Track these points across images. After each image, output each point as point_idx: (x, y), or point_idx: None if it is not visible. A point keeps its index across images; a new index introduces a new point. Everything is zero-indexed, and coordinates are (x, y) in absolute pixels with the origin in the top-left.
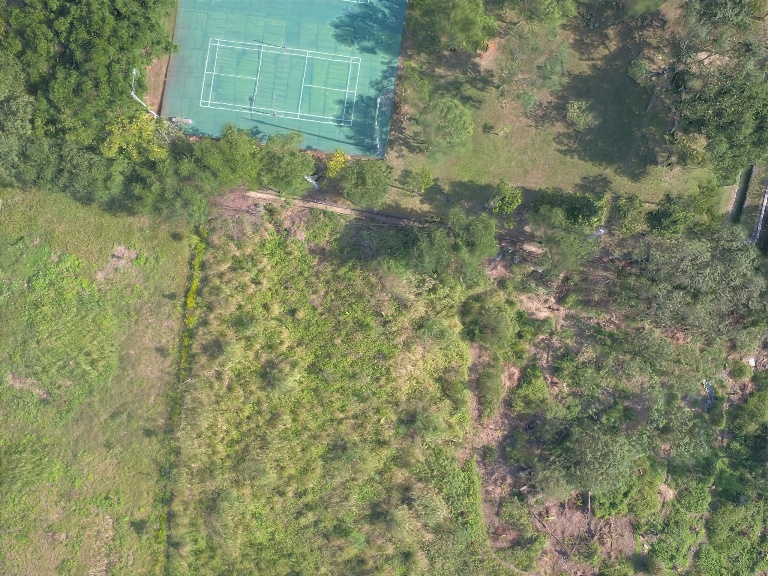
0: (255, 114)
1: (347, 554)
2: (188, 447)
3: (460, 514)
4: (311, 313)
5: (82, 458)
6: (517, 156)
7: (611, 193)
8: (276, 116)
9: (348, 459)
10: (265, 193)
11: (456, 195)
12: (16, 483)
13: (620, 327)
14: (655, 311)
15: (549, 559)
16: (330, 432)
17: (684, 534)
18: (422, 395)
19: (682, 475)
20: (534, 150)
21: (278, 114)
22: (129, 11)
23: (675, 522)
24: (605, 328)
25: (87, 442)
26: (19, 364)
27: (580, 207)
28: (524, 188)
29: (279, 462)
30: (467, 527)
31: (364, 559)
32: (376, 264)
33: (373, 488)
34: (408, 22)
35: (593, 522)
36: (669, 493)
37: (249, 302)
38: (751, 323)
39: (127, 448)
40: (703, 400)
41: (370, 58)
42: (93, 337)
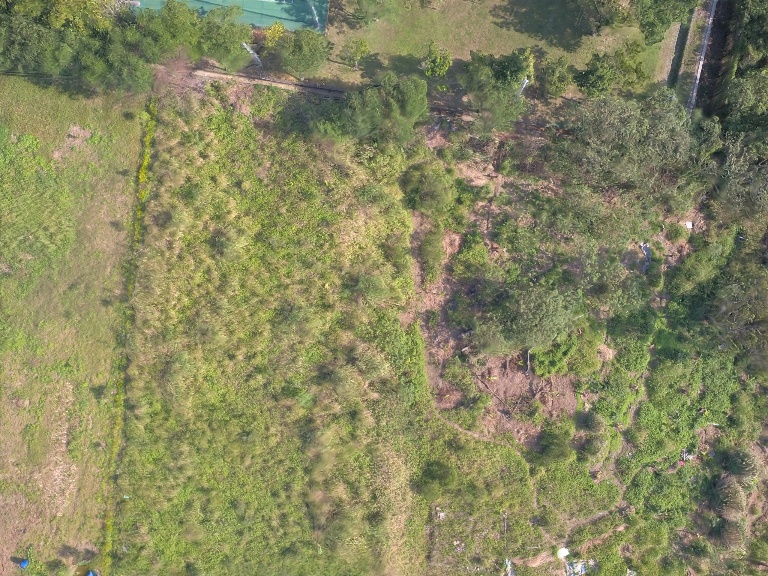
0: None
1: (295, 414)
2: (140, 311)
3: (403, 374)
4: (258, 185)
5: (43, 328)
6: (454, 29)
7: None
8: None
9: (292, 319)
10: (212, 72)
11: (396, 68)
12: None
13: (558, 193)
14: (587, 168)
15: (492, 418)
16: (276, 297)
17: (624, 392)
18: (364, 259)
19: (621, 334)
20: (471, 23)
21: None
22: None
23: (614, 380)
24: (543, 194)
25: (47, 313)
26: None
27: (508, 64)
28: (462, 60)
29: (228, 326)
30: (410, 385)
31: (311, 419)
32: (317, 132)
33: (319, 351)
34: None
35: (534, 382)
36: (608, 352)
37: (198, 175)
38: None
39: (85, 318)
40: (641, 262)
41: None
42: (51, 213)
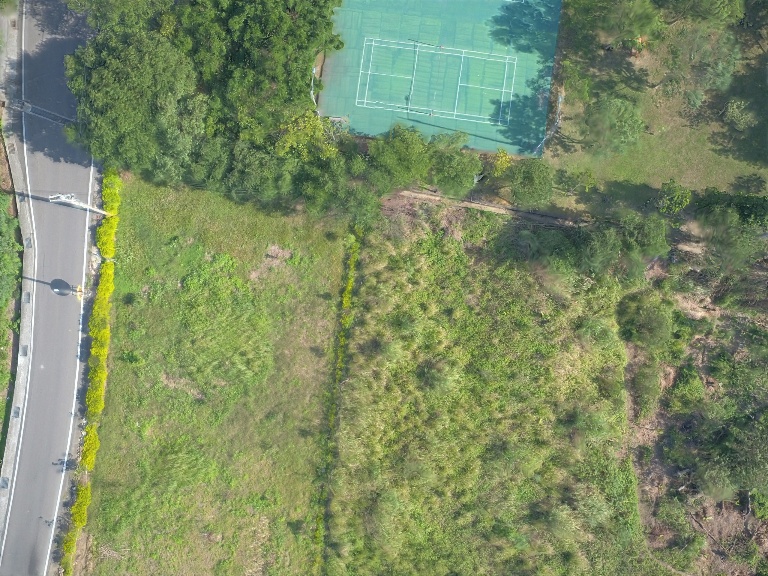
0: (411, 113)
1: (506, 554)
2: (350, 447)
3: (619, 514)
4: (467, 313)
5: (238, 458)
6: (672, 156)
7: (765, 193)
8: (432, 115)
9: (511, 459)
10: (420, 193)
11: (611, 195)
12: (172, 483)
13: None
14: None
15: (706, 559)
16: (489, 432)
17: None
18: (581, 395)
19: None
20: (689, 150)
21: (434, 113)
22: (305, 10)
23: None
24: (760, 328)
25: (243, 442)
26: (173, 364)
27: (752, 207)
28: None
29: (438, 462)
30: (628, 527)
31: (523, 559)
32: (537, 264)
33: (531, 488)
34: (563, 21)
35: (750, 522)
36: None
37: (406, 302)
38: None
39: (283, 448)
40: None
41: (526, 57)
42: (248, 337)
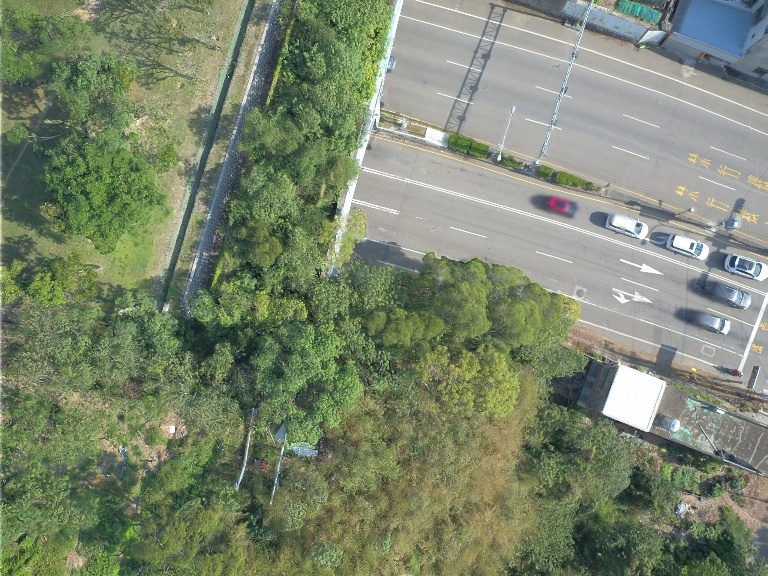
0: None
1: None
2: None
3: None
4: None
5: None
6: None
7: (36, 254)
8: None
9: None
10: None
11: None
12: None
13: (39, 390)
14: None
15: None
16: None
17: None
18: None
19: (89, 542)
20: None
21: None
22: None
23: None
24: (24, 390)
25: None
26: None
27: None
28: None
29: None
30: None
31: None
32: None
33: None
34: None
35: None
36: (77, 560)
37: None
38: (154, 391)
39: None
40: (119, 466)
41: None
42: None
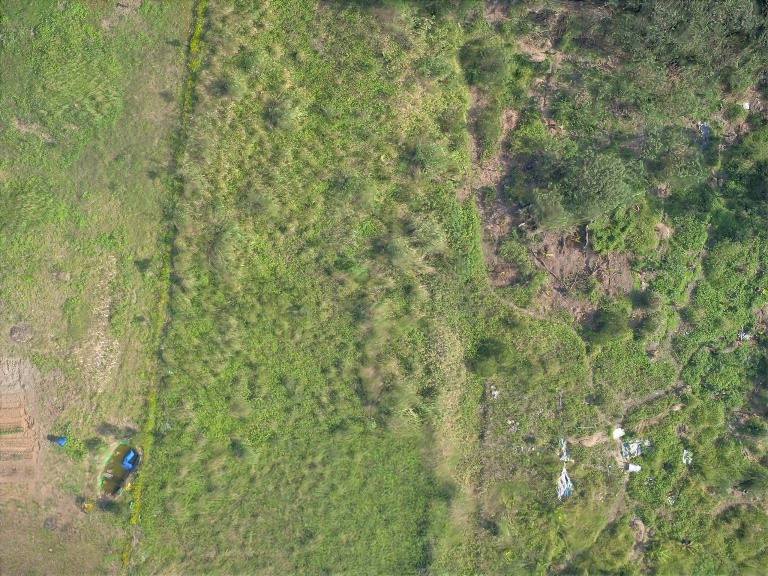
0: None
1: (348, 289)
2: (191, 178)
3: None
4: (312, 57)
5: (86, 199)
6: None
7: None
8: None
9: (348, 188)
10: None
11: None
12: (21, 223)
13: (616, 71)
14: (650, 37)
15: (548, 296)
16: (331, 168)
17: (681, 270)
18: (421, 132)
19: (678, 212)
20: None
21: None
22: None
23: (672, 258)
24: (601, 72)
25: (91, 184)
26: (25, 109)
27: None
28: None
29: (281, 198)
30: (466, 259)
31: (365, 293)
32: (375, 1)
33: (373, 224)
34: None
35: (591, 260)
36: (666, 231)
37: (251, 45)
38: (744, 59)
39: (131, 189)
40: (698, 141)
41: None
42: (98, 81)
